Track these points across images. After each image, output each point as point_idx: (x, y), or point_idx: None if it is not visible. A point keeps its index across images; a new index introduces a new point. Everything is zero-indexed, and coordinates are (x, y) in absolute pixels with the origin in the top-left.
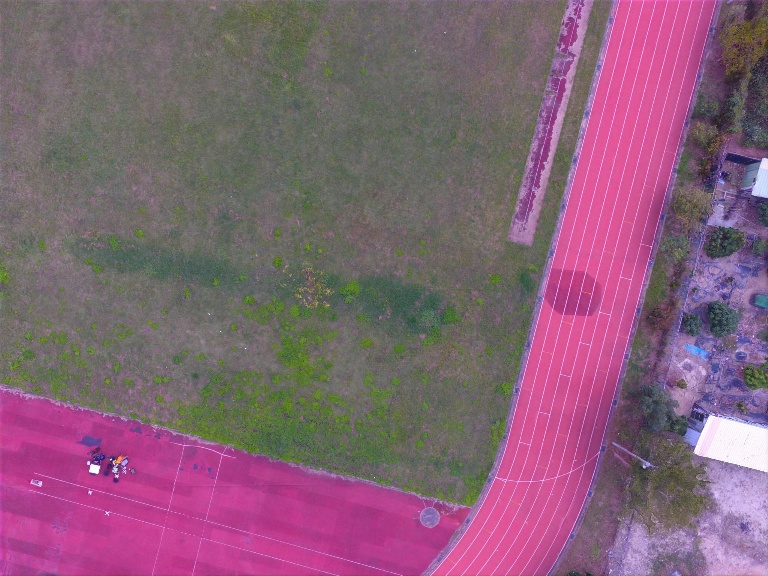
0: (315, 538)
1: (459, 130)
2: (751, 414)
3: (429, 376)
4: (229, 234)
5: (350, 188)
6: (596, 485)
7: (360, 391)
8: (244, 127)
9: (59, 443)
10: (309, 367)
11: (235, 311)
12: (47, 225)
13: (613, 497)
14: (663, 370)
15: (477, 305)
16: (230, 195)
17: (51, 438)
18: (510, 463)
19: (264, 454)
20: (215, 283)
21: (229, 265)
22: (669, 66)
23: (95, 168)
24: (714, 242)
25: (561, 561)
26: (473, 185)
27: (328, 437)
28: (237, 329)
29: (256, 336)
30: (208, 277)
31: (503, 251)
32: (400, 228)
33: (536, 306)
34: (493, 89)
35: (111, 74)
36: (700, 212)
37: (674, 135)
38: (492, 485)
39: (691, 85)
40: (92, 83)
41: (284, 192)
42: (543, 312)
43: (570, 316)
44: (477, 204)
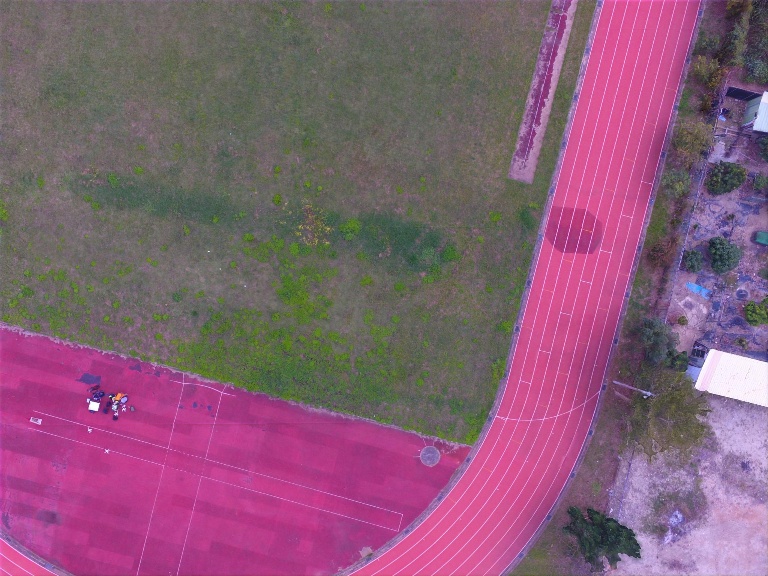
0: (315, 477)
1: (459, 67)
2: (752, 352)
3: (429, 314)
4: (228, 171)
5: (350, 125)
6: (597, 424)
7: (360, 329)
8: (243, 63)
9: (58, 381)
10: (309, 305)
11: (235, 249)
12: (46, 162)
13: (614, 436)
14: (664, 306)
15: (477, 243)
16: (229, 132)
17: (50, 376)
18: (510, 402)
19: (264, 392)
20: (214, 220)
21: (228, 202)
22: (670, 2)
23: (94, 104)
24: (715, 177)
25: (562, 500)
26: (473, 122)
27: (328, 375)
28: (237, 267)
29: (256, 274)
30: (207, 214)
31: (503, 189)
32: (400, 165)
33: (536, 244)
34: (493, 25)
35: (110, 10)
36: (701, 144)
37: (675, 72)
38: (492, 424)
39: (692, 21)
40: (91, 19)
41: (284, 129)
42: (544, 250)
43: (571, 254)
44: (477, 141)
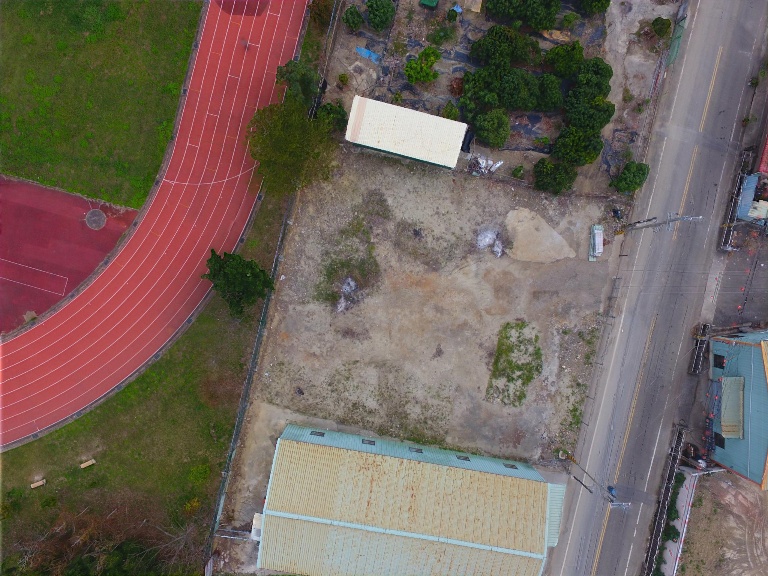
0: None
1: None
2: None
3: (93, 74)
4: None
5: None
6: (266, 188)
7: (22, 88)
8: None
9: None
10: None
11: None
12: None
13: (283, 200)
14: None
15: (142, 3)
16: None
17: None
18: (178, 165)
19: None
20: None
21: None
22: None
23: None
24: None
25: None
26: None
27: None
28: None
29: None
30: None
31: None
32: None
33: (204, 6)
34: None
35: None
36: None
37: None
38: (160, 187)
39: None
40: None
41: None
42: (211, 12)
43: (238, 16)
44: None
